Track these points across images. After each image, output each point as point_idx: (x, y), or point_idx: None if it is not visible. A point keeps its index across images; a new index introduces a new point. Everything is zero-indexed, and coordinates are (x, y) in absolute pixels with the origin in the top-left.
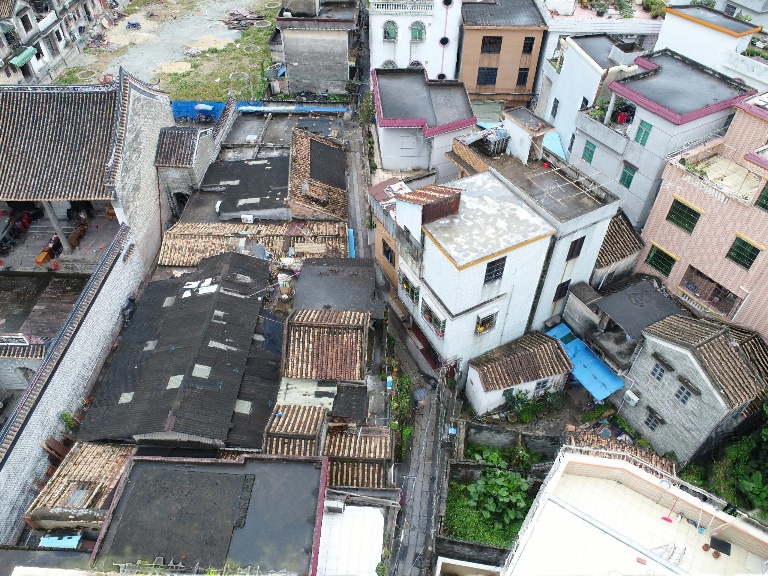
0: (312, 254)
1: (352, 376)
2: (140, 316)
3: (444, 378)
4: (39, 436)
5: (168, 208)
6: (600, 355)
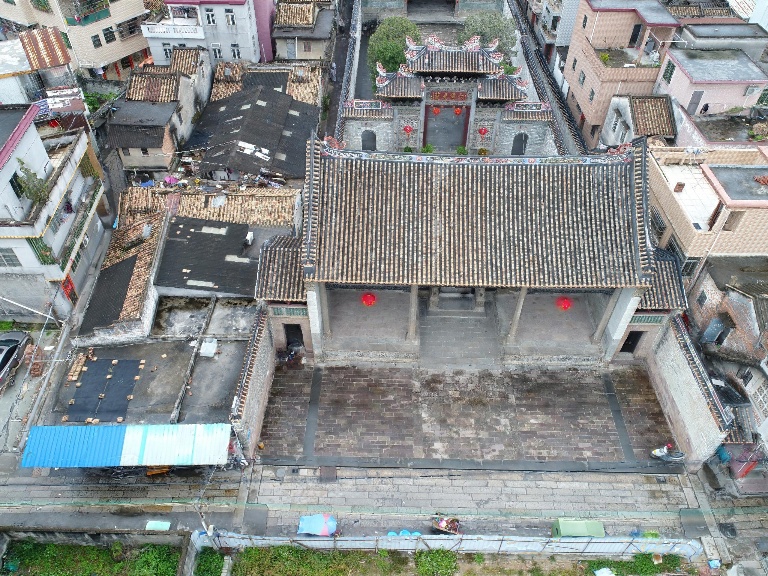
0: None
1: None
2: (303, 155)
3: None
4: None
5: None
6: None
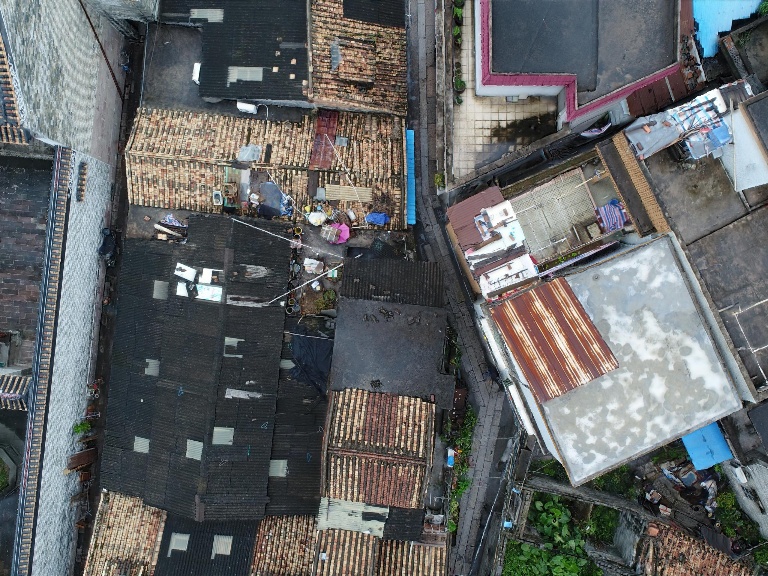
0: (352, 202)
1: (407, 505)
2: (127, 306)
3: (518, 443)
4: (58, 472)
5: (115, 33)
6: (723, 432)
